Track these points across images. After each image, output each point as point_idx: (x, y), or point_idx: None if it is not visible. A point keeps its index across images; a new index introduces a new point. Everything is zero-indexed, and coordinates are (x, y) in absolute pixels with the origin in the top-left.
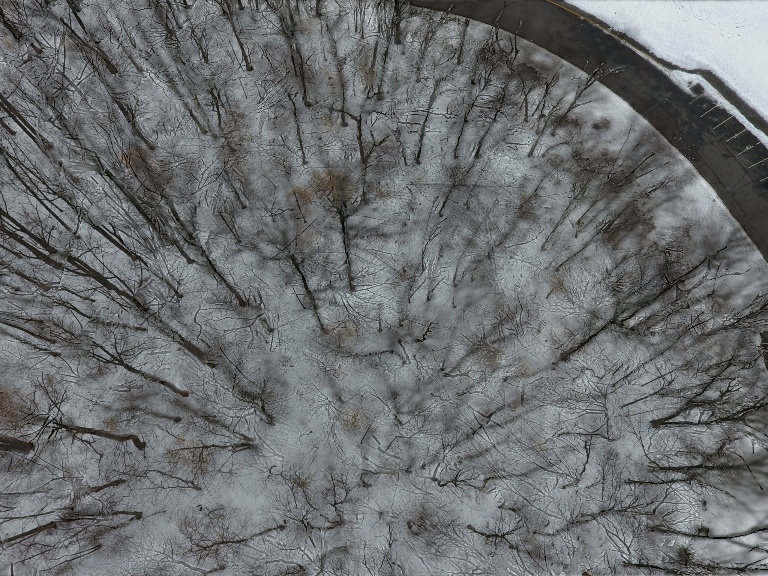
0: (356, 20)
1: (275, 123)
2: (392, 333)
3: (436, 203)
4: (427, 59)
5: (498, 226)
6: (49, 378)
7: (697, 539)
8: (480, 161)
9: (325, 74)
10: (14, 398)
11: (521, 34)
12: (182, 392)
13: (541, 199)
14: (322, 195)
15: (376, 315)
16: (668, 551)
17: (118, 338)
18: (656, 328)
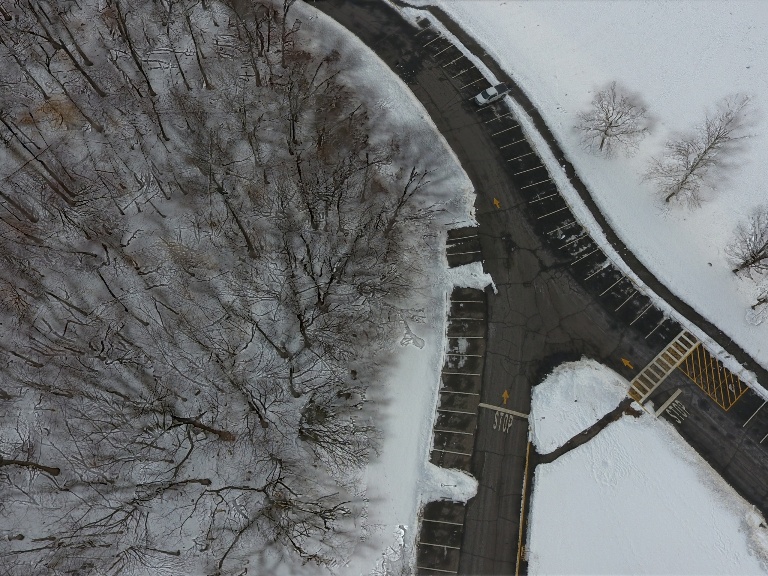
0: None
1: (25, 65)
2: (98, 240)
3: None
4: (176, 5)
5: (220, 147)
6: None
7: (337, 402)
8: (212, 92)
9: (78, 21)
10: None
11: None
12: None
13: (265, 123)
14: (56, 124)
15: None
16: (305, 412)
17: None
18: (351, 229)
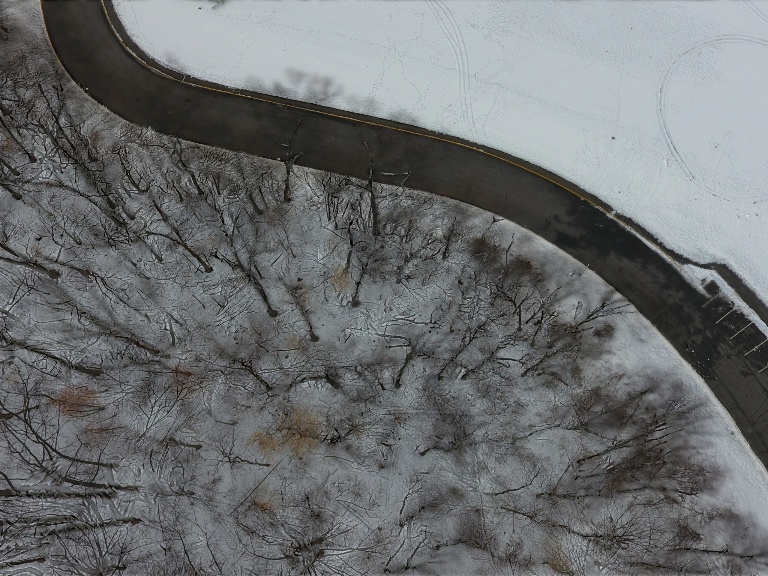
0: (329, 211)
1: (236, 338)
2: None
3: (417, 443)
4: None
5: (487, 466)
6: None
7: None
8: (467, 382)
9: (294, 275)
10: None
11: (514, 218)
12: None
13: (536, 429)
14: (287, 433)
15: None
16: None
17: None
18: None
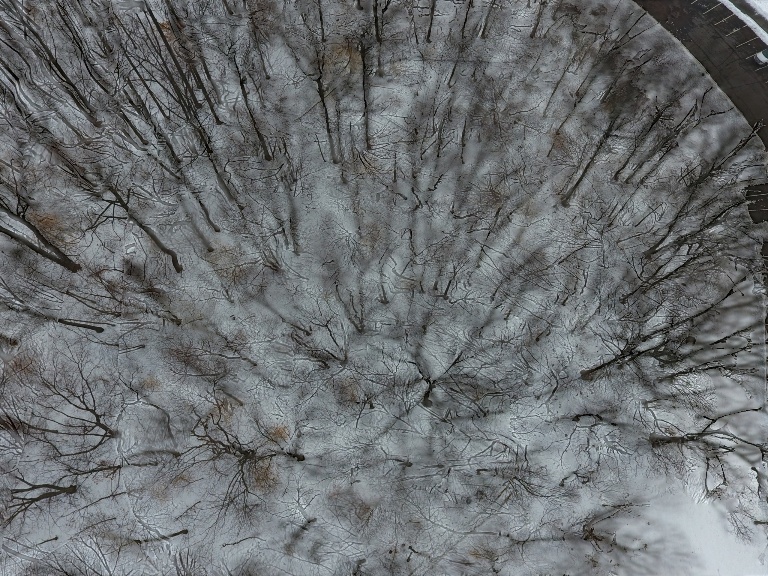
0: None
1: (296, 6)
2: (406, 183)
3: (446, 74)
4: None
5: (503, 97)
6: (93, 212)
7: (685, 347)
8: (486, 41)
9: None
10: (63, 225)
11: None
12: (214, 226)
13: (543, 74)
14: (340, 67)
15: (391, 166)
16: (658, 355)
17: (156, 178)
18: (649, 182)
